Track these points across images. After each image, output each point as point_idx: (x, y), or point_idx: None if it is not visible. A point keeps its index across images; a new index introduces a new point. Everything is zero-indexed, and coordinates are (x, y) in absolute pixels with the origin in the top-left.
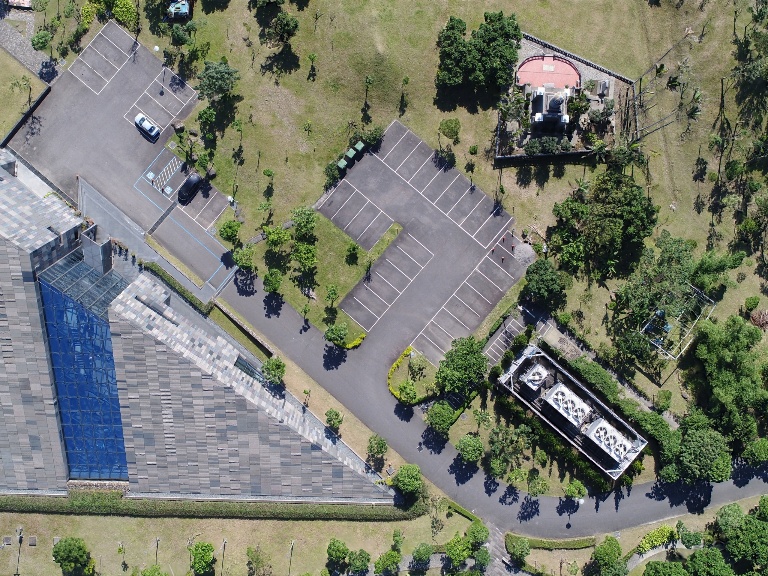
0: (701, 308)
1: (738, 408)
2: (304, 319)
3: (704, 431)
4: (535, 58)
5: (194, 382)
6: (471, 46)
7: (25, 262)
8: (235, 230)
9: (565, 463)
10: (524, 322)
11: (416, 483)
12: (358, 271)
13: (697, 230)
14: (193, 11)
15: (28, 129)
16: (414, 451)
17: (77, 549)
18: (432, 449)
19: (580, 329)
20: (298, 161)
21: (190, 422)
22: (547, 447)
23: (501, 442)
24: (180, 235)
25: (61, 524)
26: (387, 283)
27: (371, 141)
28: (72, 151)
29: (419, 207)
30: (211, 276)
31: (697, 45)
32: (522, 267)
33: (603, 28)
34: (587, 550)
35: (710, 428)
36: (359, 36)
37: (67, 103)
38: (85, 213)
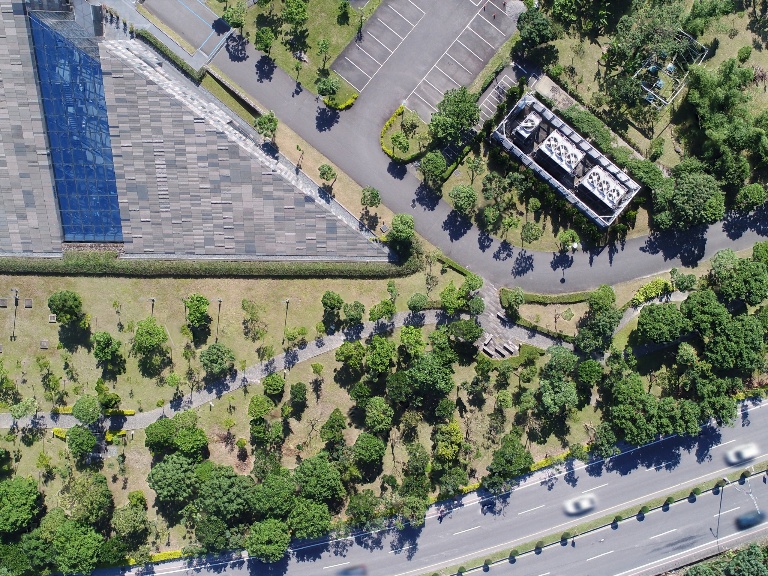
0: (693, 59)
1: (731, 148)
2: (296, 82)
3: (697, 174)
4: None
5: (186, 127)
6: None
7: None
8: None
9: (559, 218)
10: (516, 78)
11: (410, 231)
12: (349, 31)
13: None
14: None
15: None
16: (408, 208)
17: (72, 299)
18: (426, 206)
19: (572, 85)
20: None
21: (183, 173)
22: (540, 202)
23: (494, 189)
24: (171, 4)
25: (56, 286)
26: (379, 42)
27: None
28: None
29: None
30: (203, 43)
31: None
32: (514, 24)
33: None
34: (581, 305)
35: (703, 172)
36: None
37: None
38: None
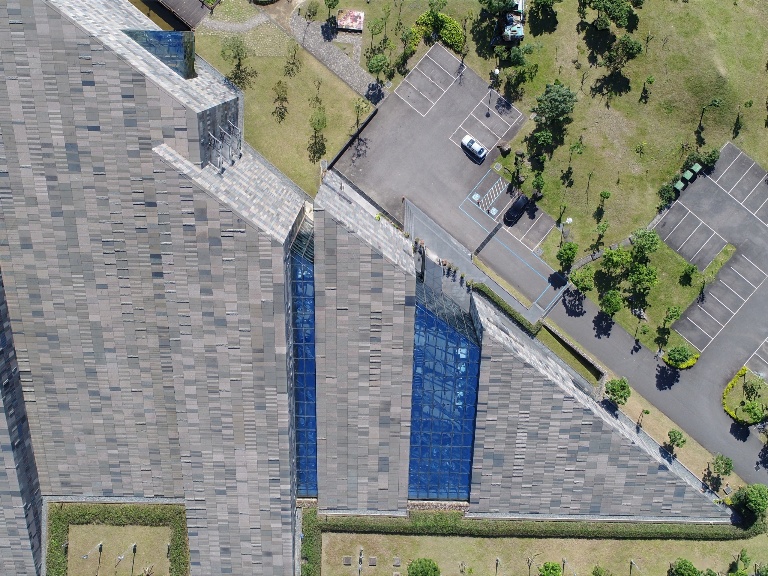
0: None
1: None
2: (635, 339)
3: None
4: None
5: (555, 404)
6: None
7: (410, 287)
8: (575, 252)
9: None
10: None
11: (767, 503)
12: (692, 292)
13: None
14: None
15: (354, 151)
16: (751, 470)
17: (433, 570)
18: None
19: None
20: (630, 183)
21: (543, 443)
22: None
23: None
24: (506, 256)
25: (401, 544)
26: (721, 304)
27: (708, 163)
28: (398, 173)
29: (752, 228)
30: (539, 297)
31: None
32: None
33: None
34: None
35: None
36: (696, 59)
37: (393, 125)
38: (413, 234)
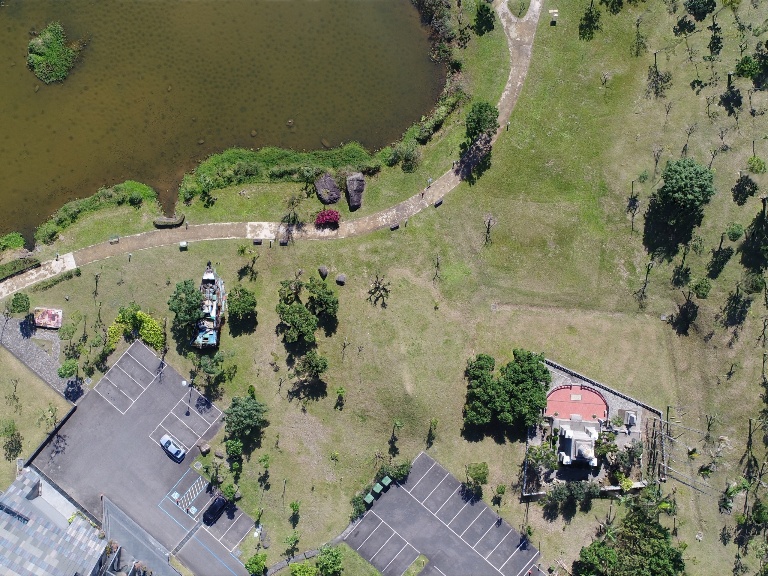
0: None
1: None
2: None
3: None
4: (563, 387)
5: None
6: (500, 388)
7: None
8: (261, 566)
9: None
10: None
11: None
12: None
13: (723, 562)
14: (220, 334)
15: (53, 448)
16: None
17: None
18: None
19: None
20: (324, 490)
21: None
22: None
23: None
24: (204, 556)
25: None
26: None
27: (398, 477)
28: (97, 470)
29: (445, 540)
30: None
31: (725, 381)
32: None
33: (631, 357)
34: None
35: None
36: (387, 371)
37: (92, 422)
38: (109, 535)
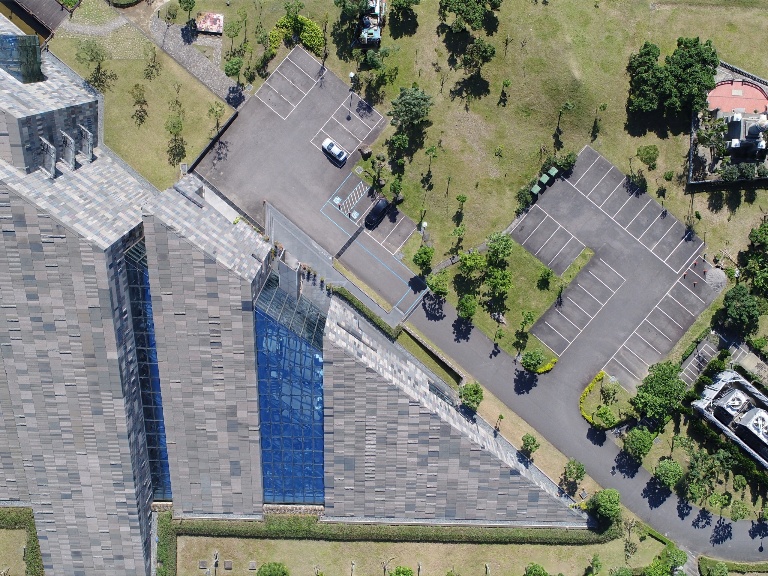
0: None
1: None
2: (494, 343)
3: None
4: (724, 83)
5: (401, 409)
6: (668, 72)
7: (246, 292)
8: (430, 256)
9: (758, 487)
10: (717, 347)
11: (617, 508)
12: (549, 296)
13: None
14: (381, 36)
15: (215, 154)
16: (607, 475)
17: (281, 574)
18: (625, 473)
19: None
20: (489, 186)
21: (392, 448)
22: (740, 471)
23: (701, 467)
24: (367, 260)
25: (256, 548)
26: (579, 308)
27: (565, 167)
28: (259, 176)
29: (611, 232)
30: (399, 300)
31: None
32: (714, 292)
33: None
34: None
35: None
36: (553, 62)
37: (254, 128)
38: (273, 238)
